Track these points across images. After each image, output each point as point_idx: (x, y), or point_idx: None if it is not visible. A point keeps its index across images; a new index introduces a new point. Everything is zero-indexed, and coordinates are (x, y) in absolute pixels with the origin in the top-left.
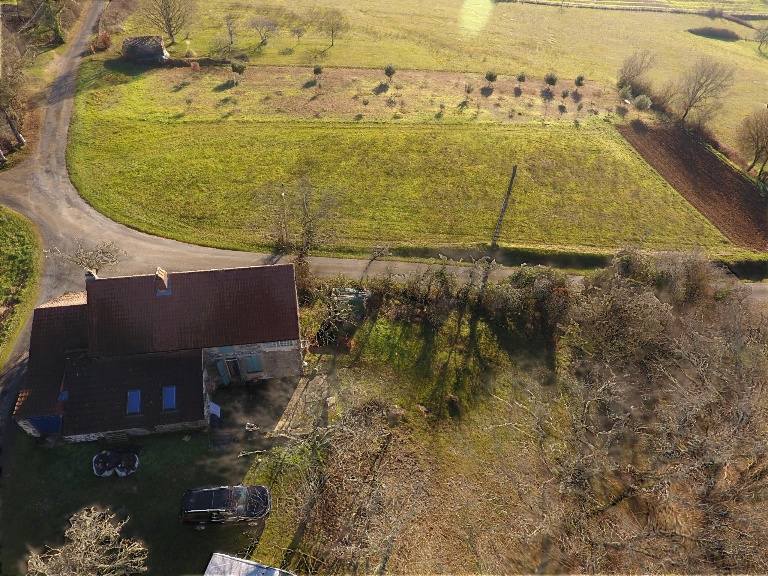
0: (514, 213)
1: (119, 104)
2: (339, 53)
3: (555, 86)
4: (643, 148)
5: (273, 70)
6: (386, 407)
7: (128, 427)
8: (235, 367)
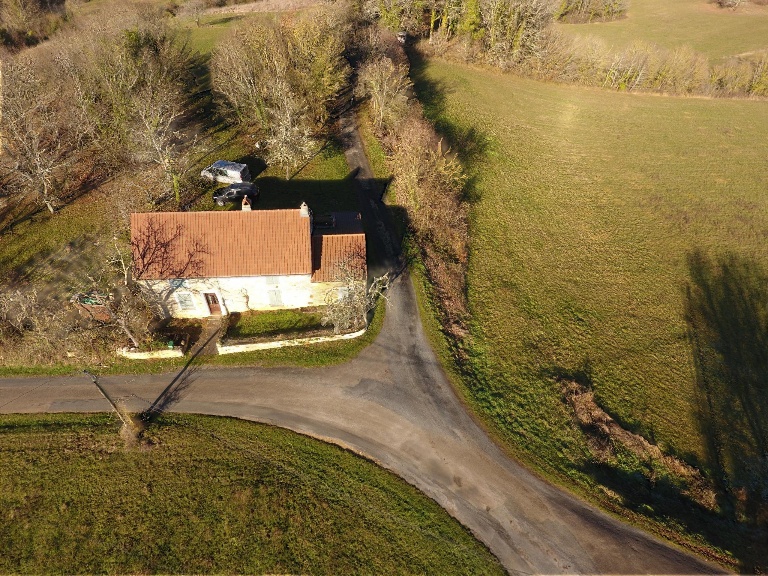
0: None
1: None
2: None
3: None
4: None
5: None
6: None
7: None
8: None
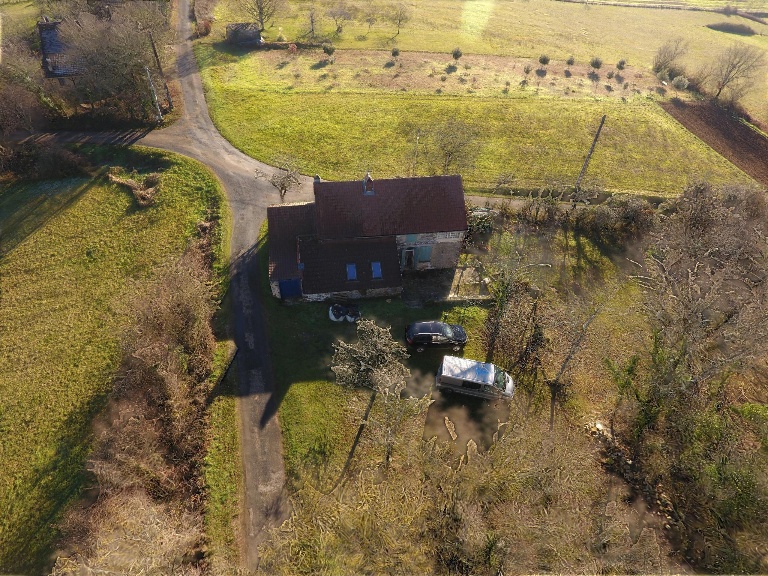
0: (587, 166)
1: (237, 78)
2: (406, 40)
3: (599, 70)
4: (685, 120)
5: (355, 53)
6: (528, 286)
7: (350, 289)
8: (410, 257)
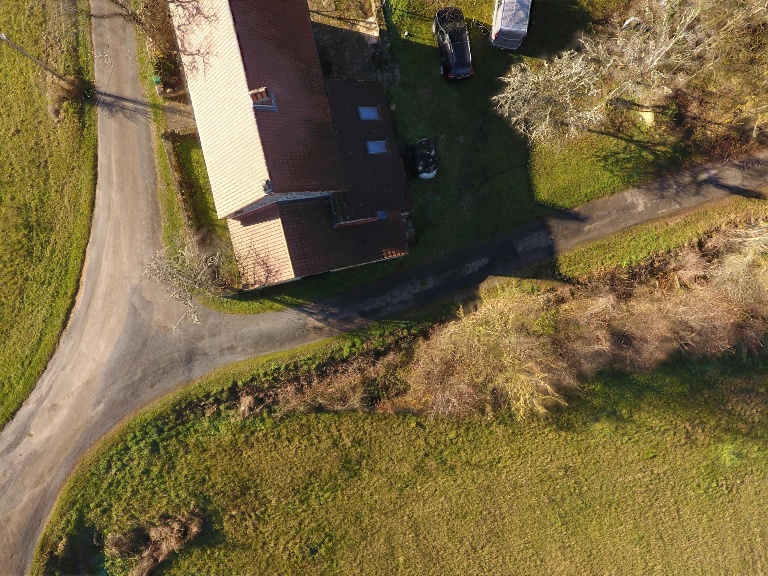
0: None
1: None
2: None
3: None
4: None
5: None
6: None
7: None
8: None
